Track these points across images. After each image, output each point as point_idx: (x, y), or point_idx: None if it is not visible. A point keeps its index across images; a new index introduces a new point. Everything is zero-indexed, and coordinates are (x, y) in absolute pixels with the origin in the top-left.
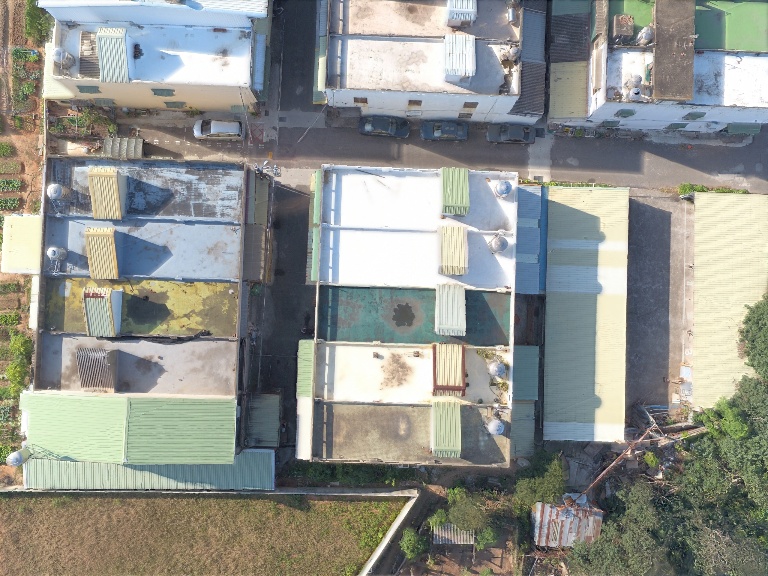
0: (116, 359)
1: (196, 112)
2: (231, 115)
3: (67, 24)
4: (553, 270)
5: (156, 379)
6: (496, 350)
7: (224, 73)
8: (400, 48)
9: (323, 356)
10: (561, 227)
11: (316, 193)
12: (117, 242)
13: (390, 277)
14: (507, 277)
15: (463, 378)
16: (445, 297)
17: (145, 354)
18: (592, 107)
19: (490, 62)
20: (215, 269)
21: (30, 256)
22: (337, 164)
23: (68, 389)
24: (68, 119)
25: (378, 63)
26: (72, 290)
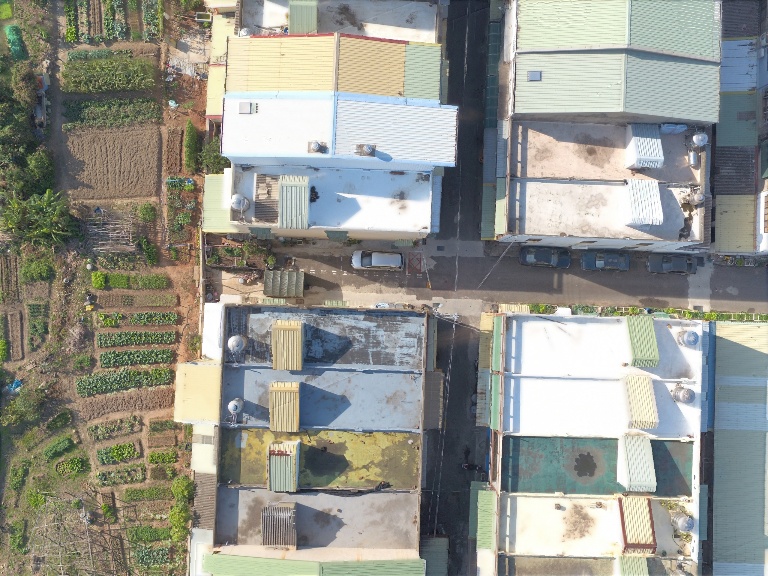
0: (295, 513)
1: (354, 241)
2: (388, 244)
3: (241, 166)
4: (721, 408)
5: (335, 532)
6: (679, 501)
7: (401, 216)
8: (579, 191)
9: (504, 508)
10: (729, 364)
11: (495, 340)
12: (299, 395)
13: (571, 426)
14: (689, 426)
15: (653, 535)
16: (632, 450)
17: (323, 507)
18: (763, 244)
19: (670, 205)
20: (394, 419)
21: (204, 405)
22: (496, 294)
23: (245, 543)
24: (223, 248)
25: (557, 206)
26: (248, 441)
